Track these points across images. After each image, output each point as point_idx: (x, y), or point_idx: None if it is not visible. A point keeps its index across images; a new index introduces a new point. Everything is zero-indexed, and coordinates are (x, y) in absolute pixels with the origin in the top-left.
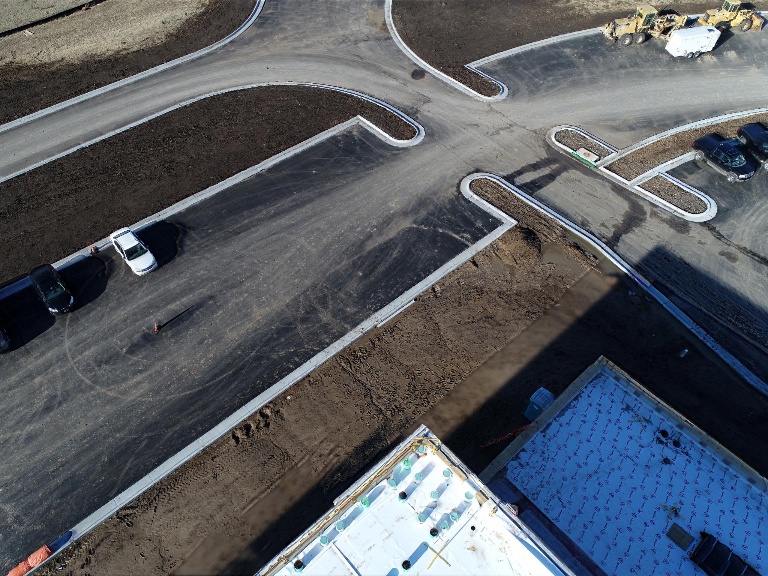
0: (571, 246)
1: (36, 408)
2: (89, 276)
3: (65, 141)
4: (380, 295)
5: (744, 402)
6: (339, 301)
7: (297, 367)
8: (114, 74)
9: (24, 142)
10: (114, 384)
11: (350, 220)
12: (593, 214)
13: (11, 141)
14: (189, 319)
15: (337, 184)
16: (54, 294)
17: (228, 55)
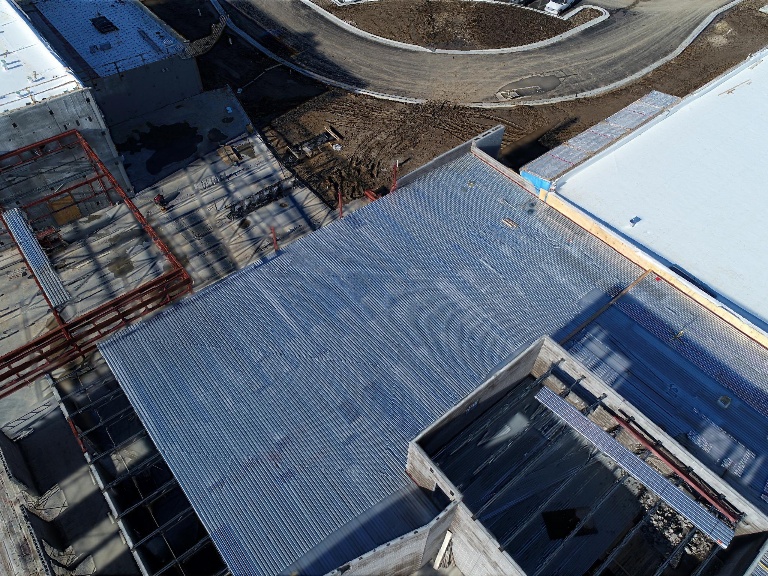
0: None
1: None
2: None
3: None
4: None
5: None
6: None
7: None
8: None
9: None
10: None
11: None
12: None
13: None
14: None
15: None
16: None
17: None
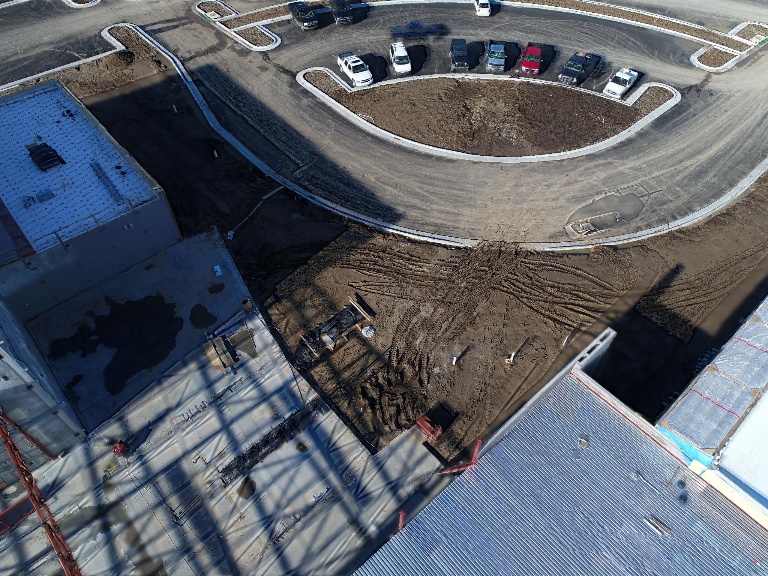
0: (152, 60)
1: None
2: None
3: None
4: None
5: (196, 133)
6: None
7: None
8: None
9: None
10: None
11: (8, 46)
12: (187, 46)
13: None
14: None
15: (13, 27)
16: None
17: None
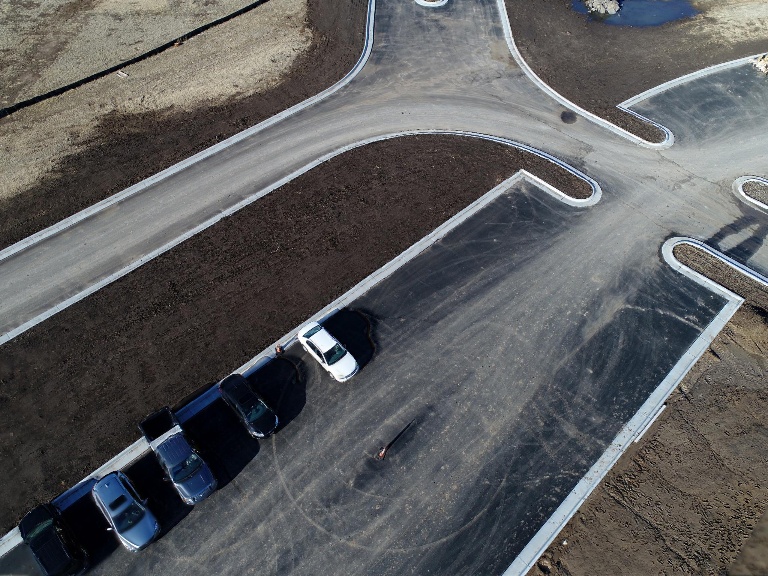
0: None
1: (270, 568)
2: (282, 384)
3: (202, 208)
4: (623, 399)
5: None
6: (579, 408)
7: (562, 500)
8: (235, 123)
9: (156, 210)
10: (353, 531)
11: (555, 301)
12: None
13: (140, 209)
14: (414, 438)
15: (526, 255)
16: (256, 414)
17: (354, 98)
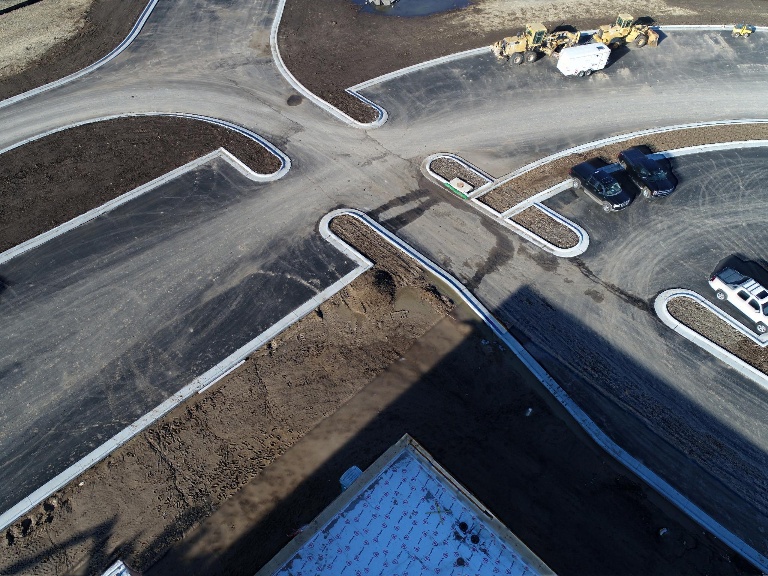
0: (427, 290)
1: None
2: None
3: None
4: (208, 355)
5: (588, 466)
6: (161, 364)
7: (98, 446)
8: None
9: None
10: None
11: (191, 267)
12: (457, 252)
13: None
14: None
15: (185, 226)
16: None
17: (93, 83)
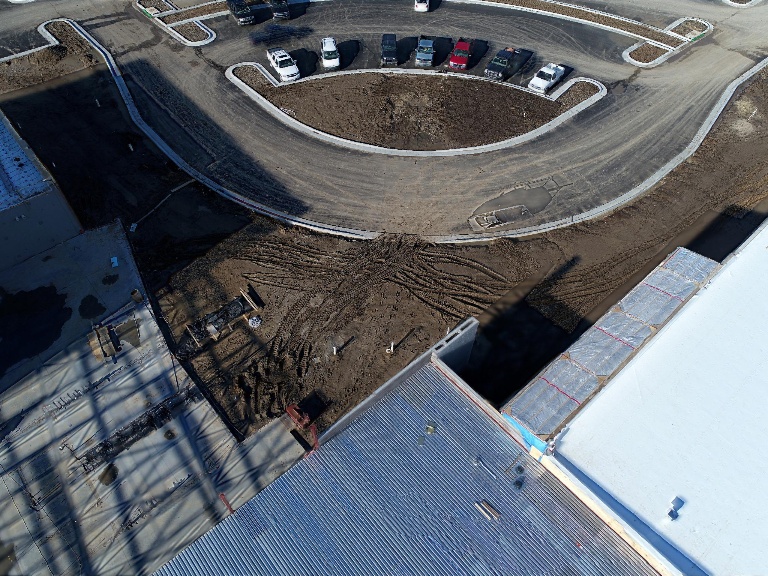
0: (84, 55)
1: None
2: None
3: None
4: None
5: (116, 127)
6: None
7: None
8: None
9: None
10: None
11: None
12: (121, 41)
13: None
14: None
15: None
16: None
17: None
